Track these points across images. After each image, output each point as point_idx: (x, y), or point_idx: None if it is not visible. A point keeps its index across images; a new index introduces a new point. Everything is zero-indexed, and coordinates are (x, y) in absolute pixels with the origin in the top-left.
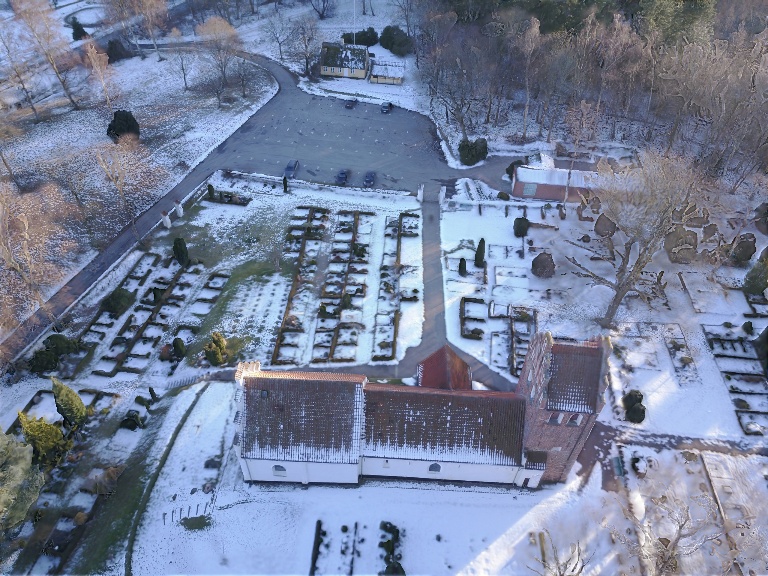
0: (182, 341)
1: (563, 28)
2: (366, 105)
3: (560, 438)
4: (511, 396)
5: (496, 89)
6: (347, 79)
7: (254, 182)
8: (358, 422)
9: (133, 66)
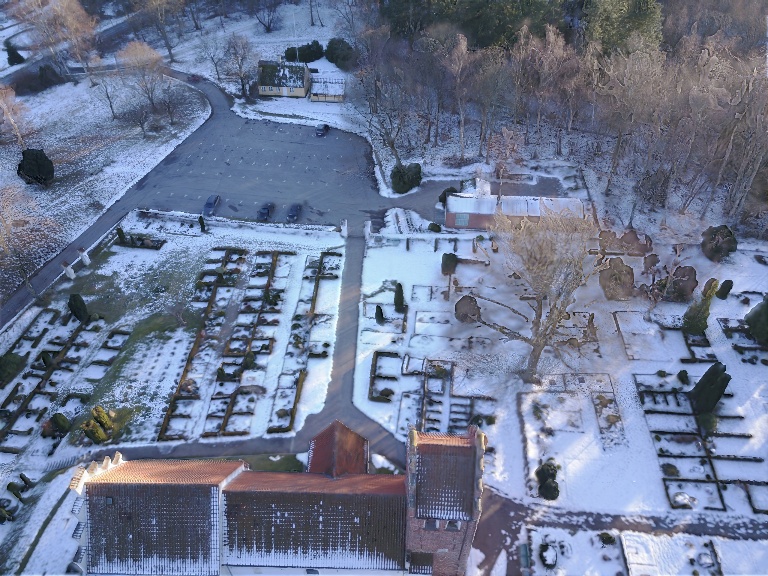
0: (63, 416)
1: (503, 39)
2: (301, 128)
3: (443, 541)
4: (391, 491)
5: (441, 103)
6: (286, 98)
7: (171, 221)
8: (216, 529)
9: (64, 93)
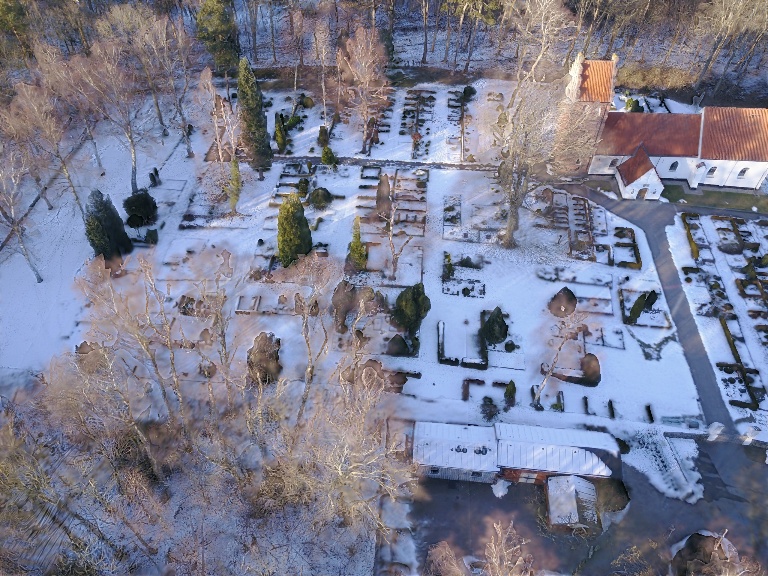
0: None
1: None
2: None
3: None
4: (609, 115)
5: None
6: None
7: None
8: None
9: None
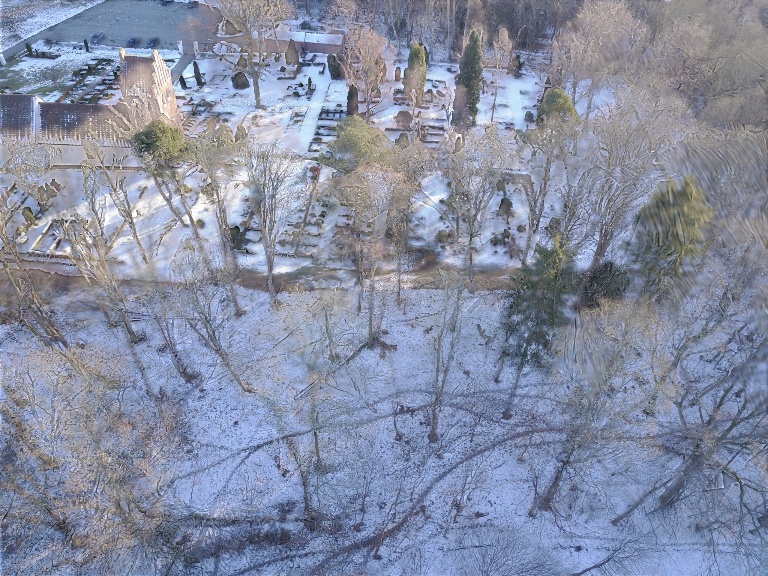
0: None
1: None
2: (179, 4)
3: None
4: None
5: None
6: None
7: (67, 46)
8: (34, 120)
9: None
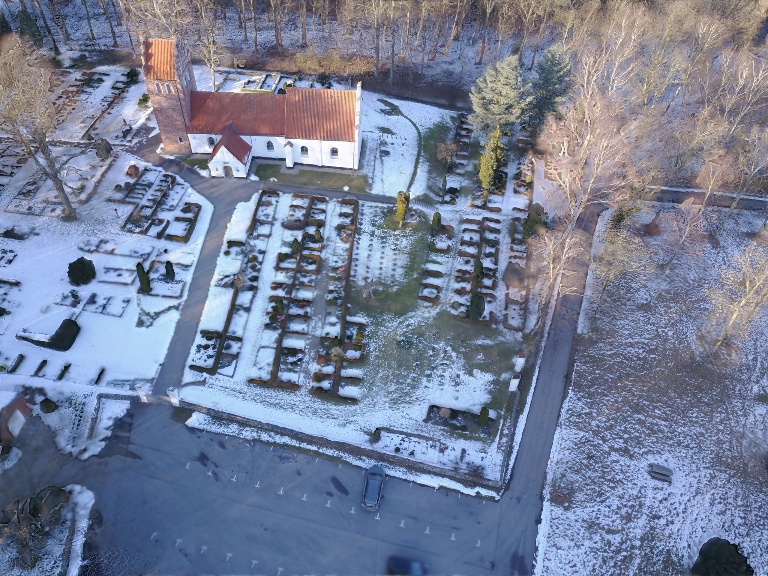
0: (434, 217)
1: None
2: None
3: None
4: (198, 94)
5: None
6: None
7: None
8: None
9: None
